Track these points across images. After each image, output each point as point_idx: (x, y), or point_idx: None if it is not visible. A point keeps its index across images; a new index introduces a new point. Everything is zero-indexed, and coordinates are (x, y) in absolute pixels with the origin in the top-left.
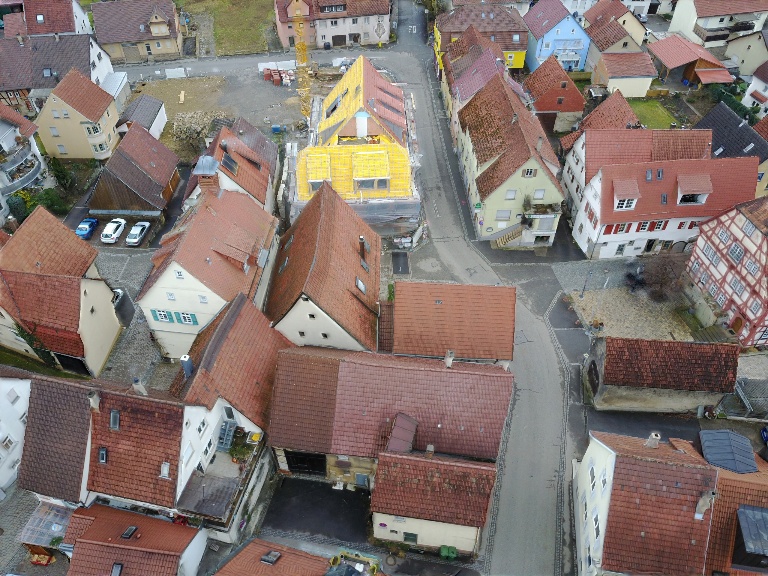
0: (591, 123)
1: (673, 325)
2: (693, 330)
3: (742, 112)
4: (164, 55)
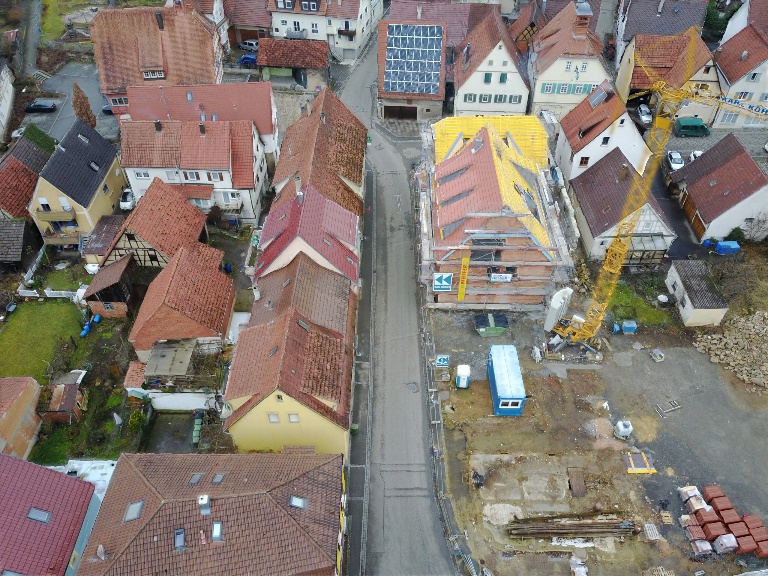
0: (178, 245)
1: None
2: None
3: None
4: None
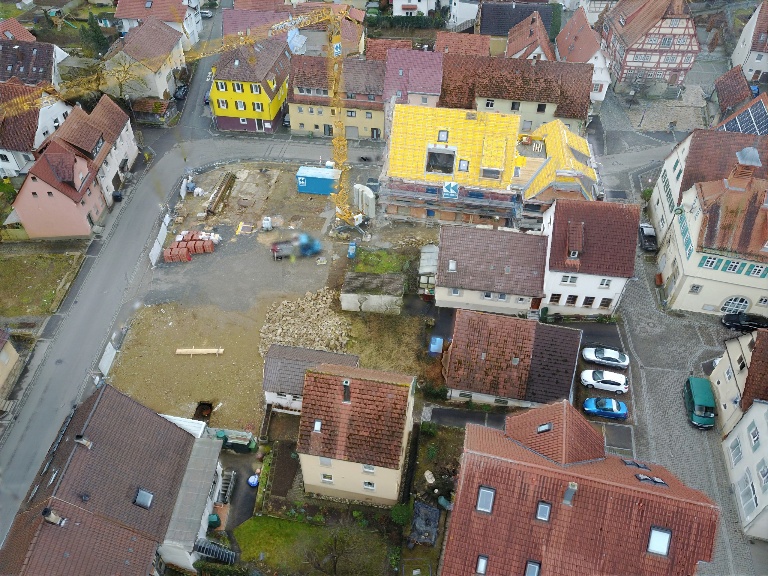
0: None
1: (660, 103)
2: (664, 99)
3: (422, 20)
4: (7, 381)
